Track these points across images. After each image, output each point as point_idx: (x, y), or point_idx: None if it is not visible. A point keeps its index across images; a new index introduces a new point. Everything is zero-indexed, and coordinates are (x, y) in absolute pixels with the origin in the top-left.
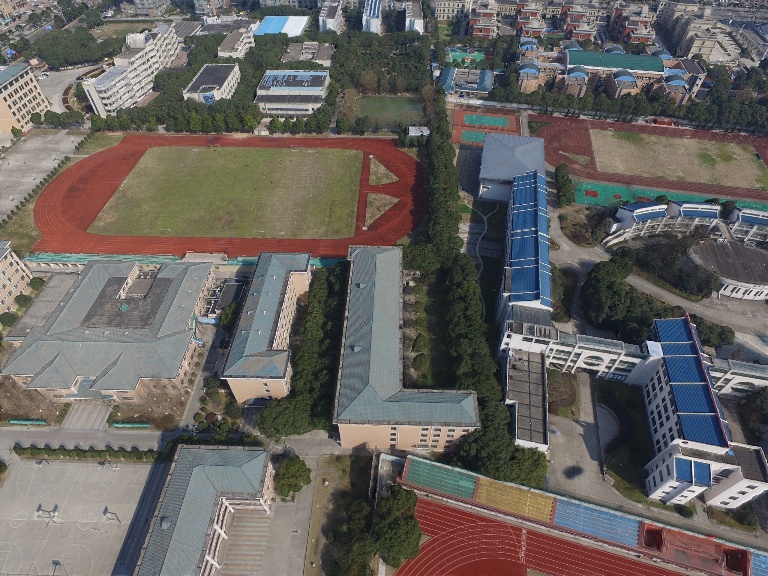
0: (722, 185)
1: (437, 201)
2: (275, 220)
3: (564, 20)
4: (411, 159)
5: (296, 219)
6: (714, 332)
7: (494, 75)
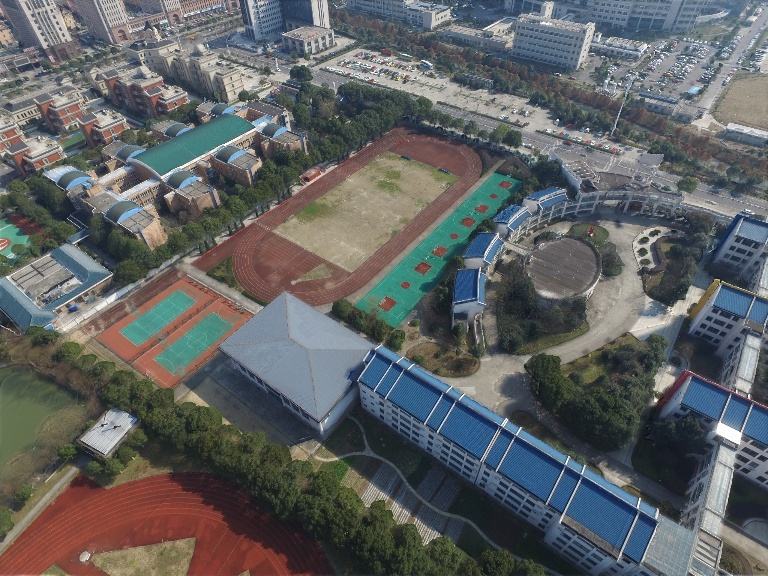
0: (431, 203)
1: (338, 526)
2: None
3: (56, 120)
4: (156, 482)
5: None
6: (662, 351)
7: (76, 246)
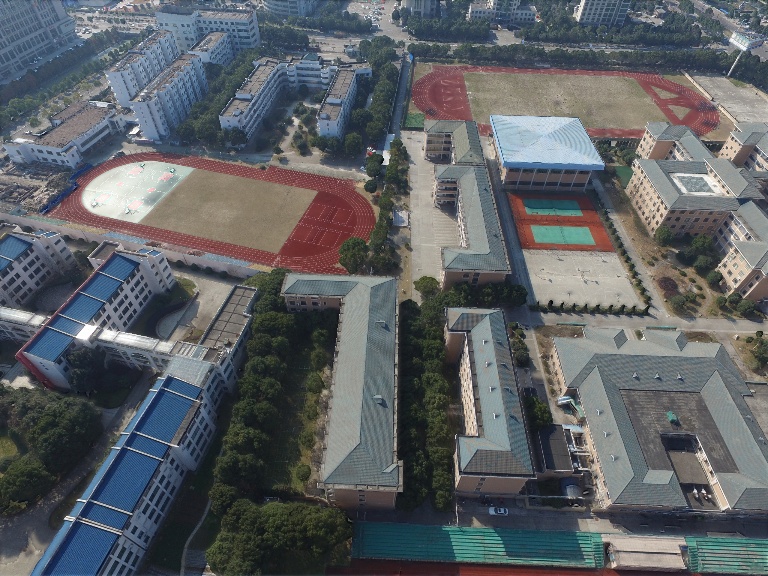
0: None
1: None
2: None
3: None
4: None
5: None
6: None
7: None
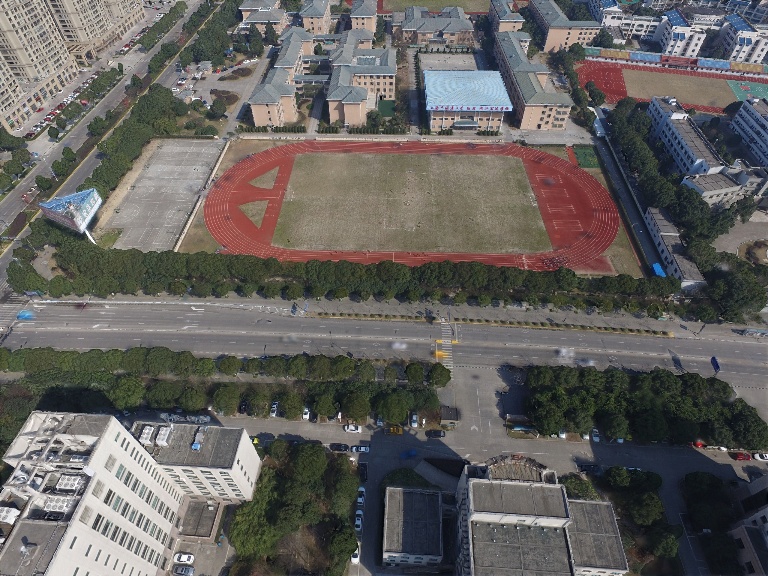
0: None
1: None
2: (474, 7)
3: None
4: None
5: (484, 7)
6: None
7: None
